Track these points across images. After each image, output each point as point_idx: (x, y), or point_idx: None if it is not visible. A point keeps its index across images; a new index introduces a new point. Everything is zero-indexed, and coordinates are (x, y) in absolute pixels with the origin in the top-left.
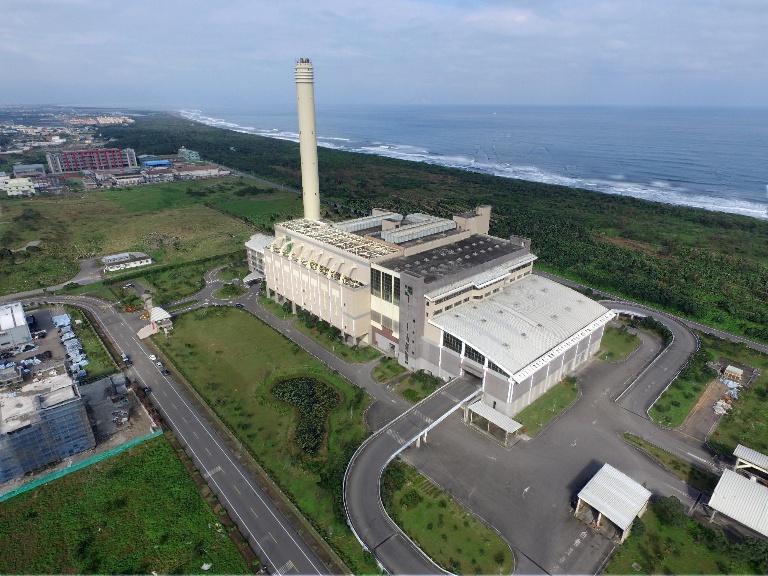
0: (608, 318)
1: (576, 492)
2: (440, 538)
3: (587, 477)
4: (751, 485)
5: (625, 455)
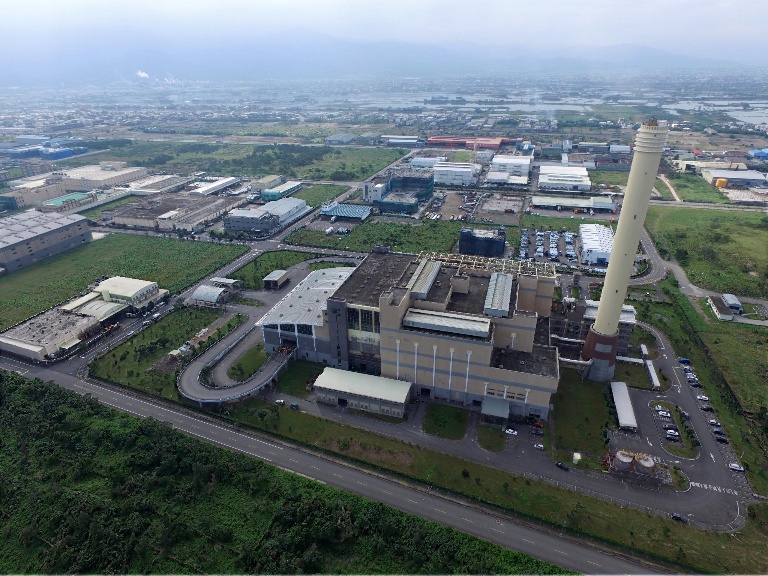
0: (262, 319)
1: (288, 284)
2: (329, 265)
3: (283, 288)
4: (226, 281)
5: (266, 298)
